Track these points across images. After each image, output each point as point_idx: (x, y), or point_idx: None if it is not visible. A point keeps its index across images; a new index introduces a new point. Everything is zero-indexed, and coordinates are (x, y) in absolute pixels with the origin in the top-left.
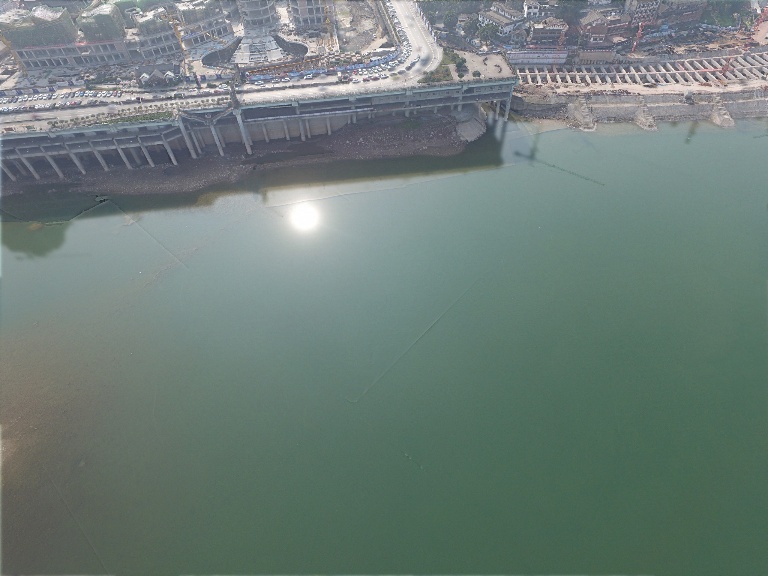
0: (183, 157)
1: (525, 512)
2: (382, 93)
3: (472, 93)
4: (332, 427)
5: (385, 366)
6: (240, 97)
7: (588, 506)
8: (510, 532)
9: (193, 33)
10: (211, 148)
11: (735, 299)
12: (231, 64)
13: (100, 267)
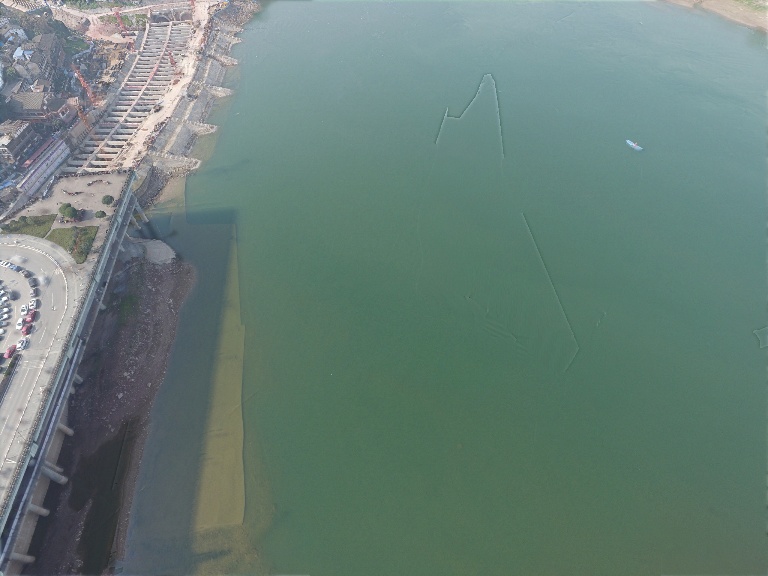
0: None
1: (601, 267)
2: (83, 308)
3: None
4: (579, 394)
5: (549, 317)
6: None
7: (590, 234)
8: (619, 275)
9: None
10: None
11: (423, 137)
12: None
13: None
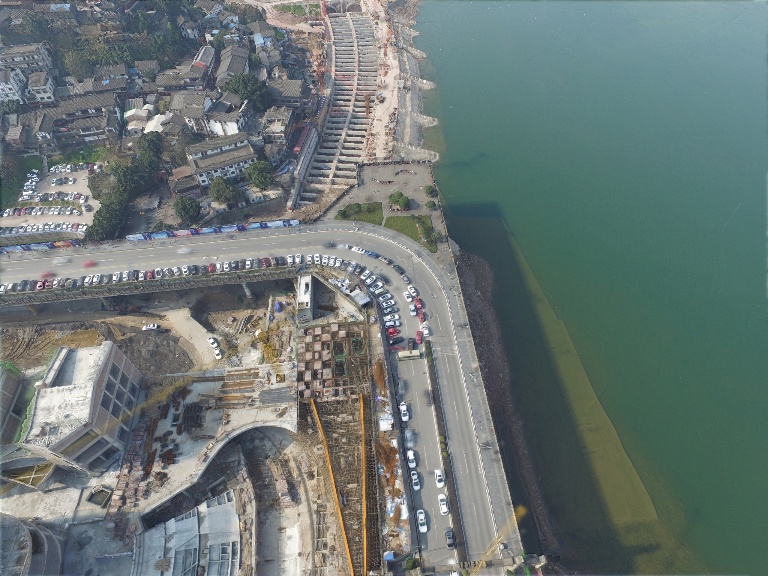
0: None
1: None
2: None
3: None
4: None
5: None
6: None
7: None
8: None
9: None
10: None
11: (653, 137)
12: None
13: None
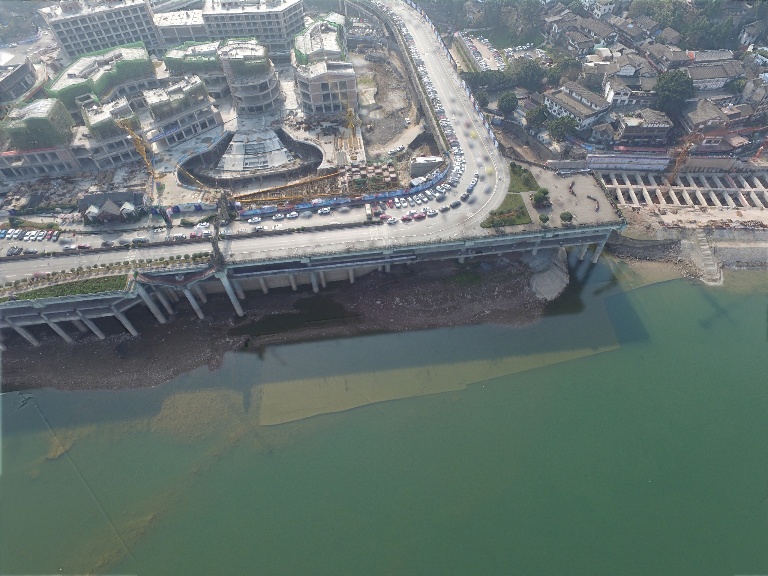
0: (147, 320)
1: None
2: (431, 245)
3: (556, 237)
4: None
5: None
6: (226, 247)
7: None
8: None
9: (167, 131)
10: (187, 304)
11: None
12: (218, 172)
13: (0, 552)
